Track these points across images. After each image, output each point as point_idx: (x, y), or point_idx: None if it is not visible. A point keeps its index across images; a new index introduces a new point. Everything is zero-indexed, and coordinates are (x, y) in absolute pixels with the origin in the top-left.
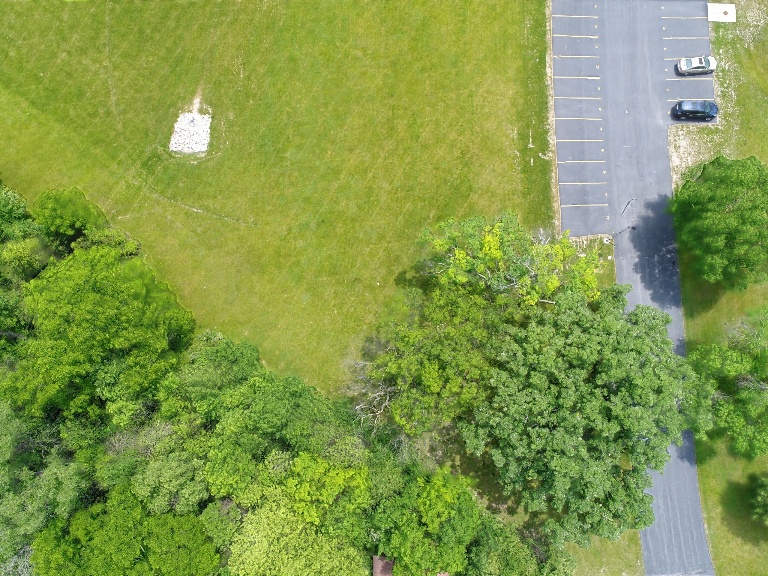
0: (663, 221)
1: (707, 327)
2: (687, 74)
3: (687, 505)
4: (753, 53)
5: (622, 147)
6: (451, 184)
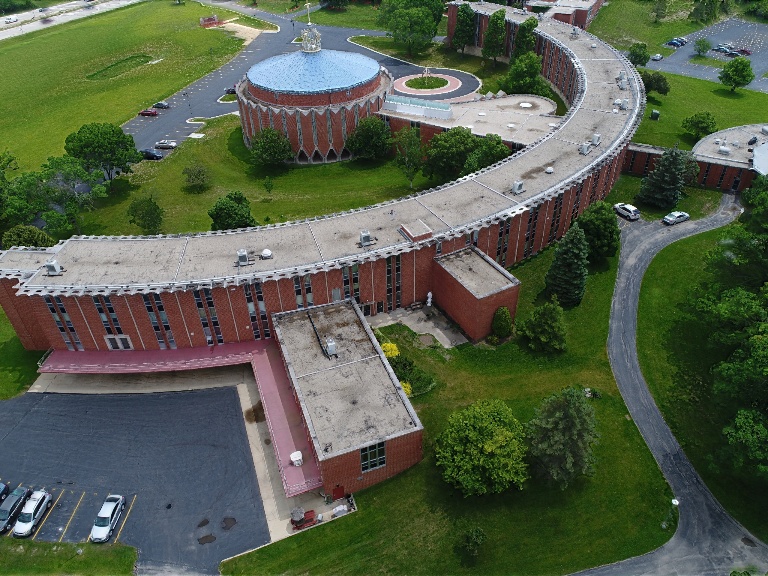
0: None
1: None
2: (160, 148)
3: None
4: (200, 145)
5: None
6: (7, 174)
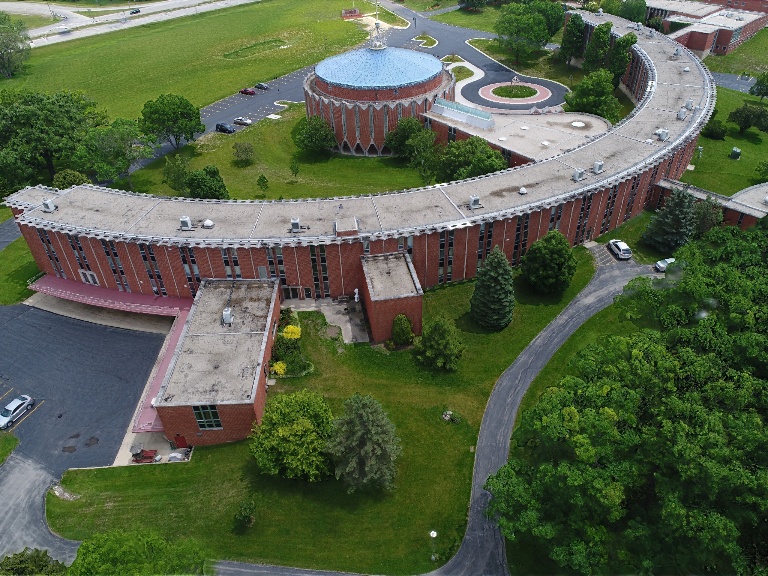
0: (171, 148)
1: (142, 173)
2: (237, 124)
3: None
4: None
5: None
6: None
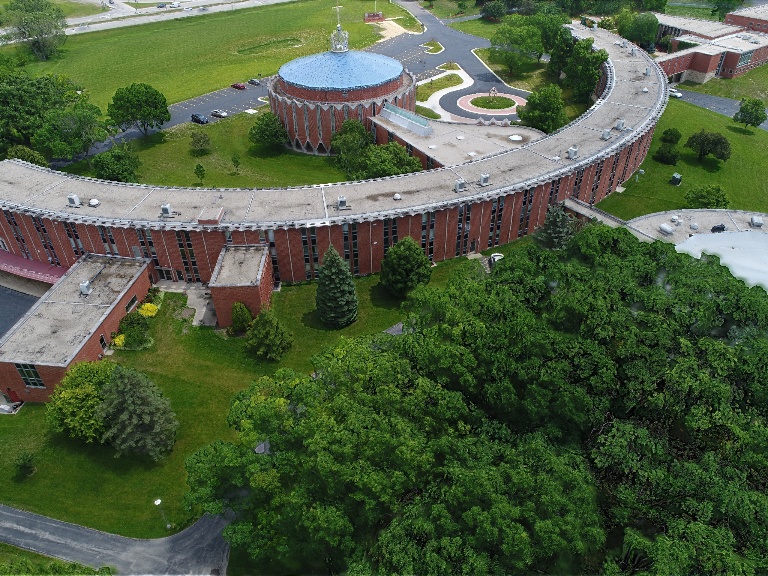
0: None
1: None
2: None
3: None
4: None
5: None
6: None
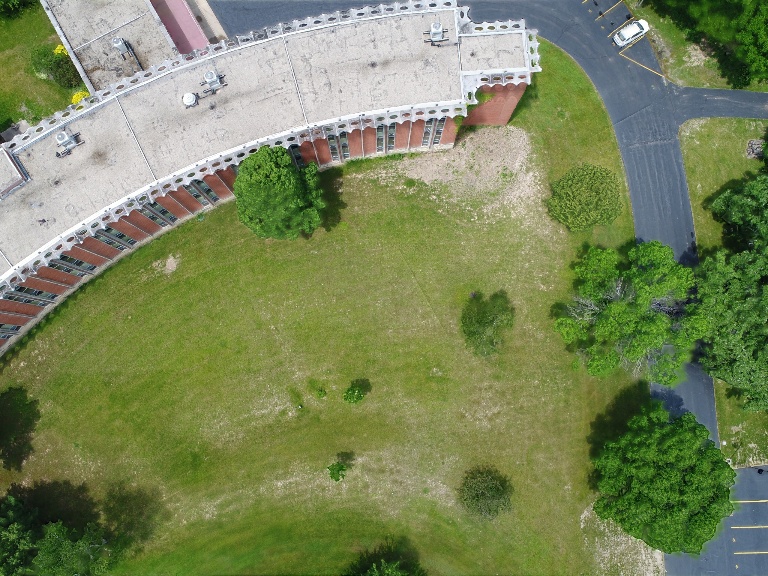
0: None
1: None
2: None
3: (644, 202)
4: None
5: (716, 571)
6: None
